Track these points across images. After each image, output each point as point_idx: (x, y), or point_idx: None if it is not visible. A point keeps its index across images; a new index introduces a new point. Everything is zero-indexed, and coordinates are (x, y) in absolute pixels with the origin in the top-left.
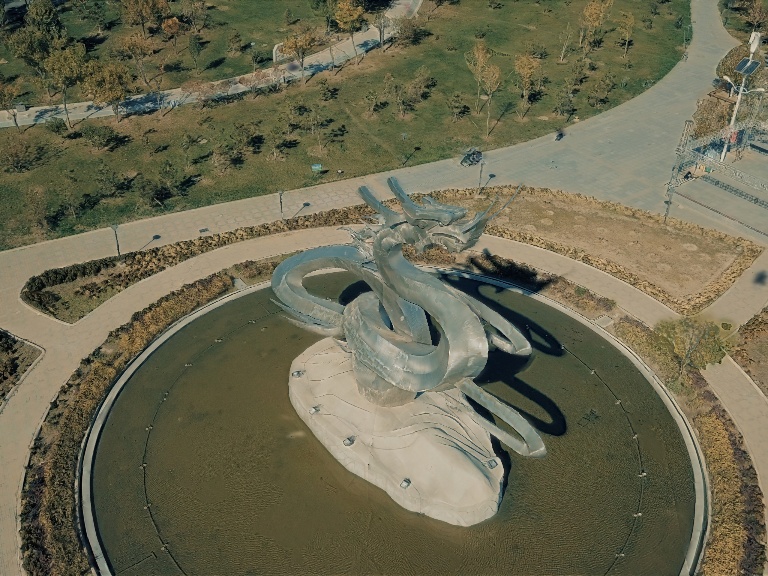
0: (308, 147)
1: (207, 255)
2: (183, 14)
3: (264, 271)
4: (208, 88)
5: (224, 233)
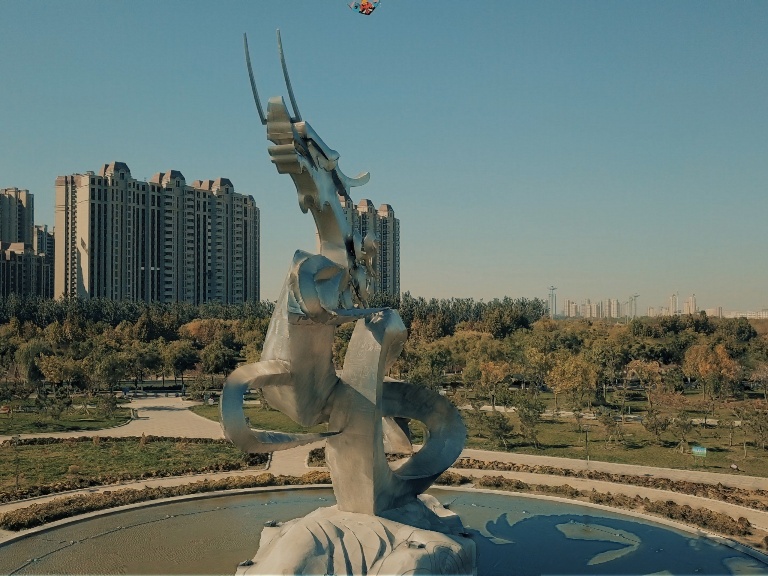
0: (734, 454)
1: (481, 471)
2: (750, 378)
3: (505, 486)
4: (678, 401)
5: (521, 464)
